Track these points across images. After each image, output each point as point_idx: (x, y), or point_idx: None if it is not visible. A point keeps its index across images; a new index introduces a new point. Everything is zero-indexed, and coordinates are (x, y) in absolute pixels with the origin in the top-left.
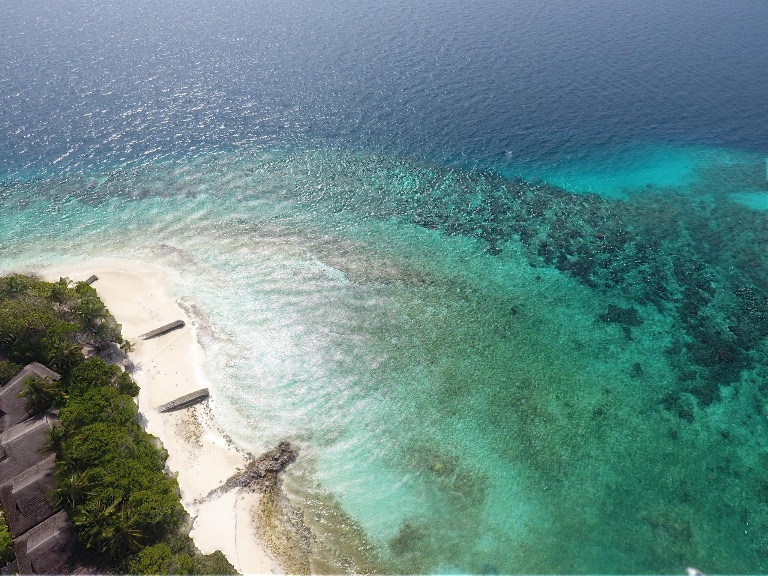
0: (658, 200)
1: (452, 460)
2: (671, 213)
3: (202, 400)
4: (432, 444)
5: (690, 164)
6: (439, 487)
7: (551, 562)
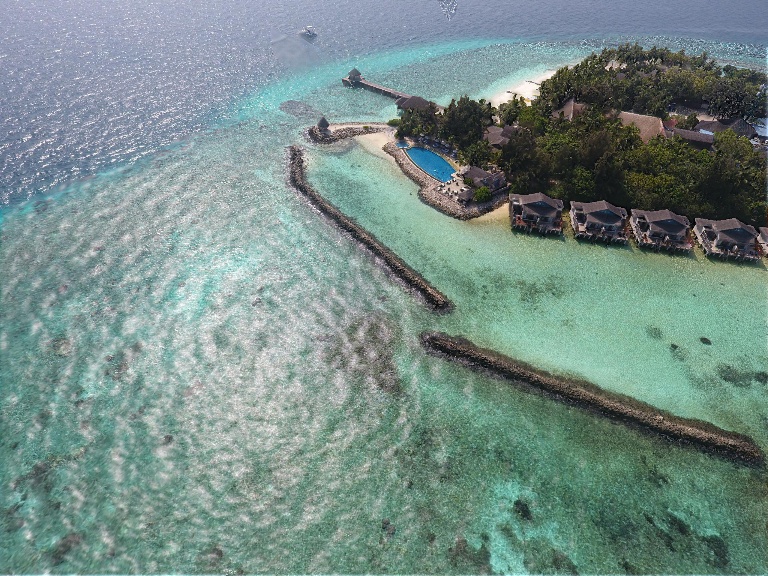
0: None
1: None
2: None
3: None
4: None
5: None
6: None
7: None
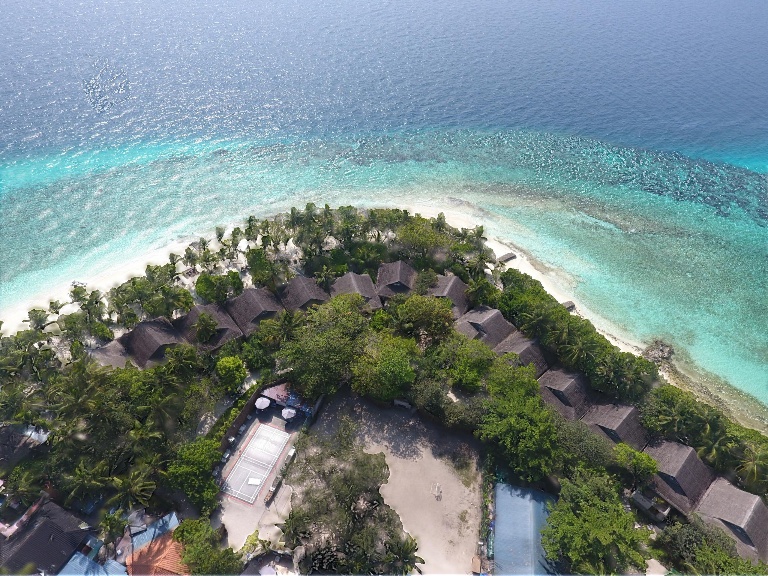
0: None
1: None
2: None
3: (572, 309)
4: None
5: None
6: None
7: None
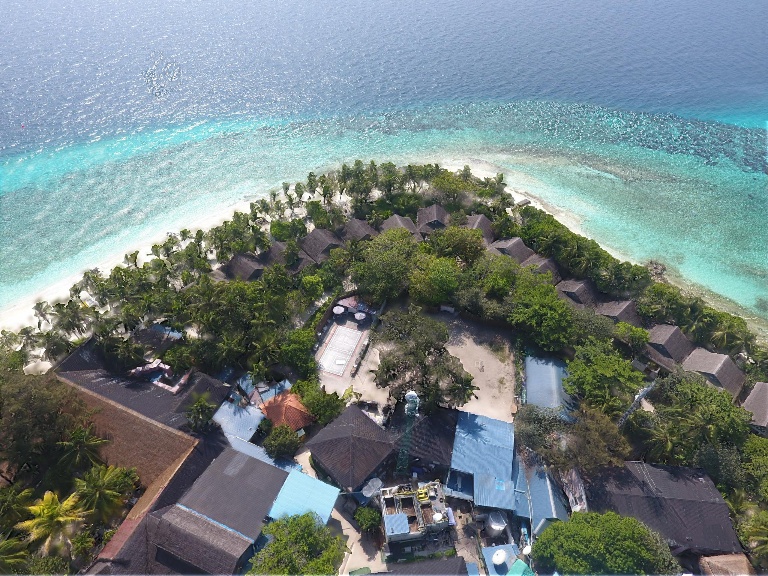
0: None
1: (765, 271)
2: None
3: None
4: (747, 263)
5: None
6: (766, 283)
7: None
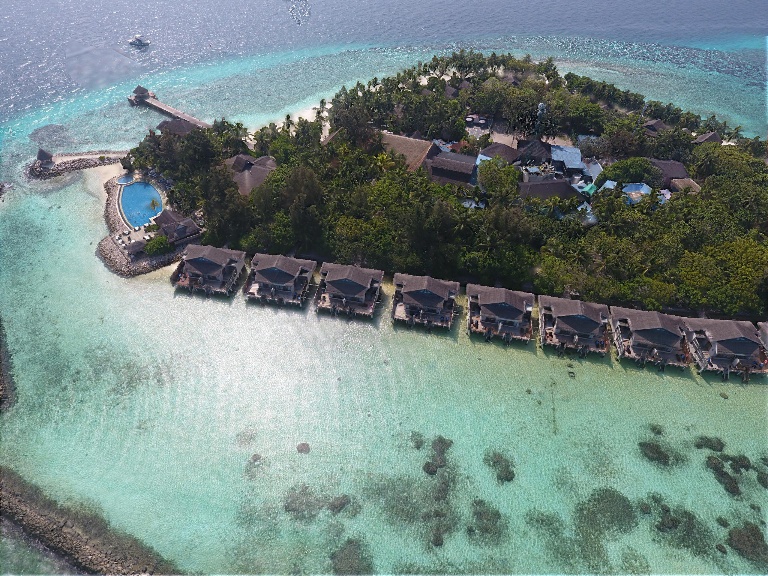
0: (753, 52)
1: (713, 112)
2: (763, 56)
3: None
4: (702, 109)
5: (763, 41)
6: None
7: (765, 129)
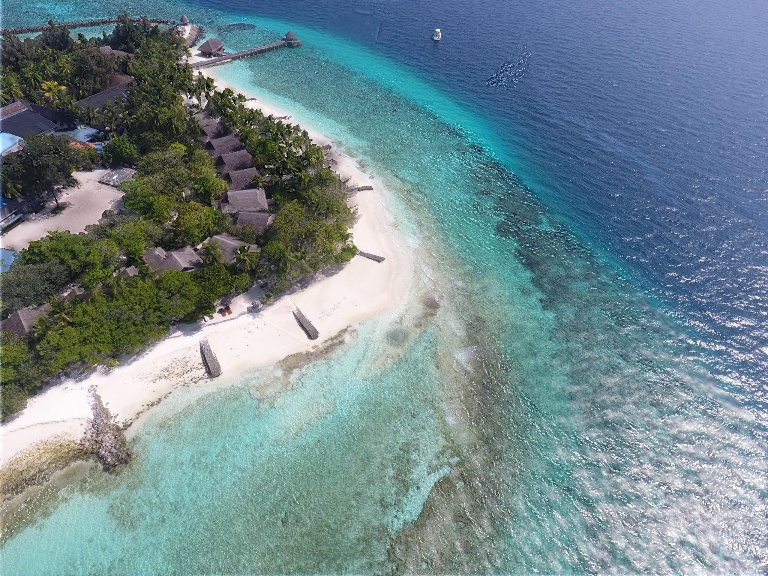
0: None
1: None
2: None
3: (209, 373)
4: None
5: None
6: None
7: None
